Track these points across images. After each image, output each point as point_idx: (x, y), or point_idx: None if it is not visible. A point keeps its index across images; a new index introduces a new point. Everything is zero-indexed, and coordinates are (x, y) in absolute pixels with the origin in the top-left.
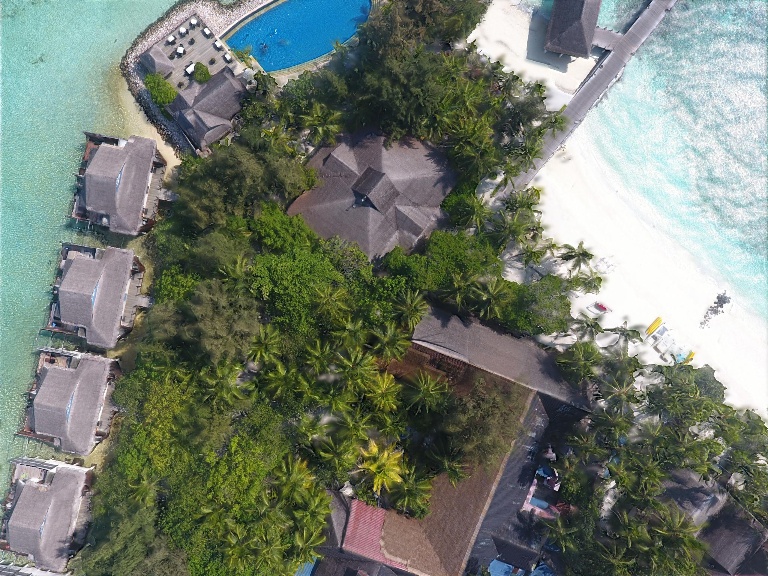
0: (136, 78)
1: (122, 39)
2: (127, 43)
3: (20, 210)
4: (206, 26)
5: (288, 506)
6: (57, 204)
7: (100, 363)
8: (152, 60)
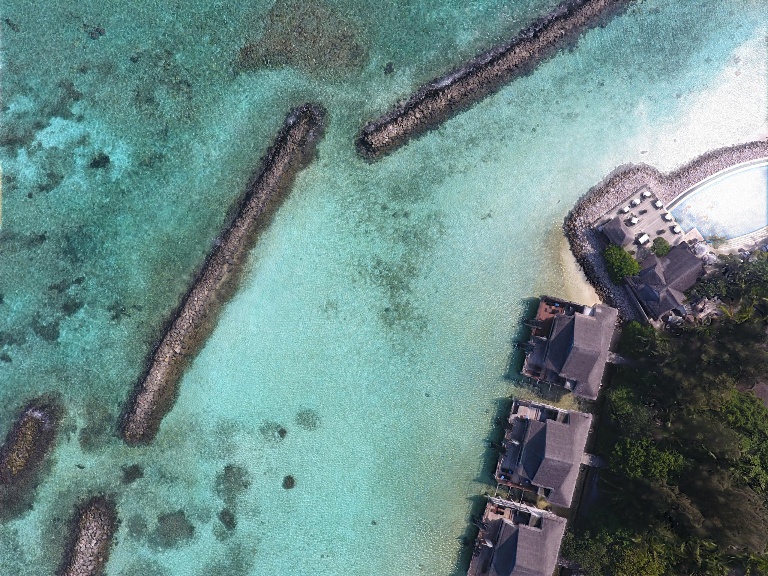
0: (584, 242)
1: (565, 200)
2: (569, 204)
3: (462, 359)
4: (656, 197)
5: None
6: (497, 355)
7: (560, 523)
8: (622, 234)
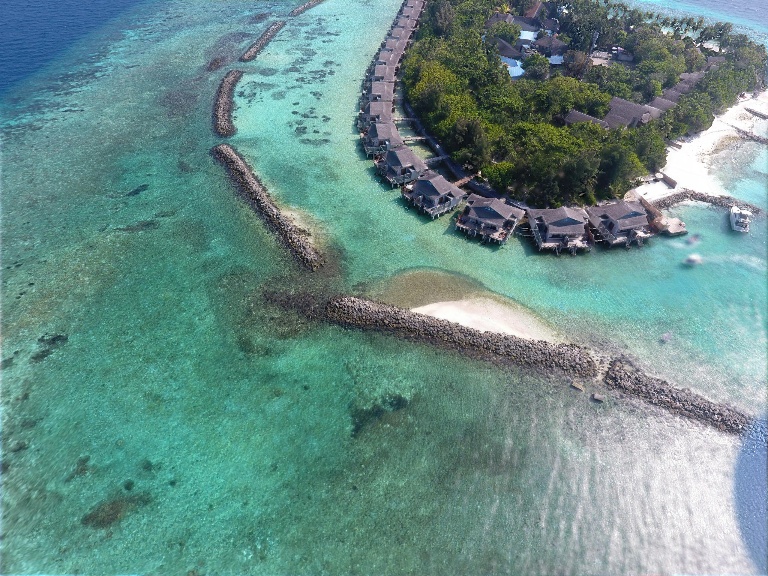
0: None
1: None
2: None
3: (386, 8)
4: None
5: (481, 5)
6: None
7: None
8: None
